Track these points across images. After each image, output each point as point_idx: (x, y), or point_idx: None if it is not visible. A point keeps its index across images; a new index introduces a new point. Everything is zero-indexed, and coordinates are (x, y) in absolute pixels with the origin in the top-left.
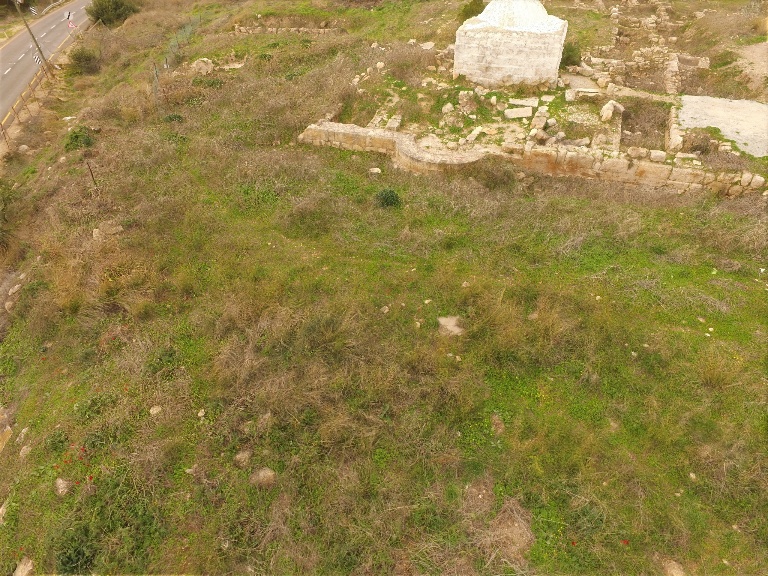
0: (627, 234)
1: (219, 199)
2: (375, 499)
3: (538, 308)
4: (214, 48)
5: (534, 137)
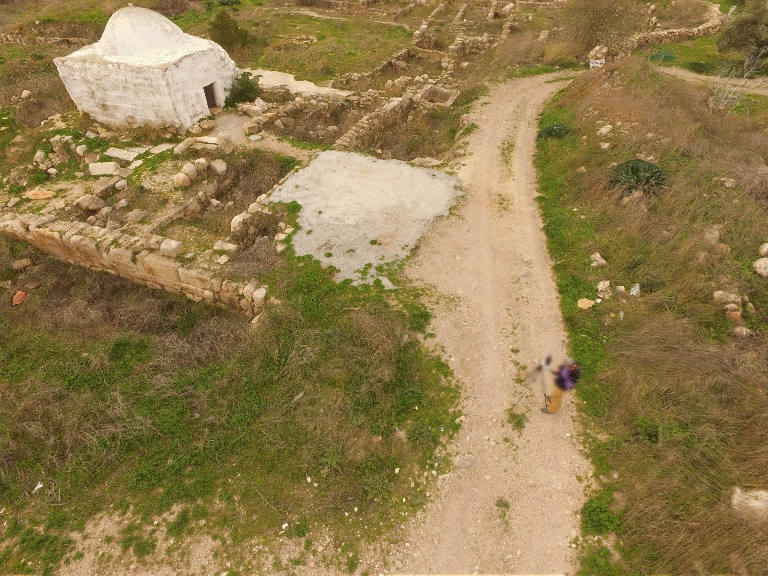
0: None
1: None
2: None
3: None
4: None
5: (77, 207)
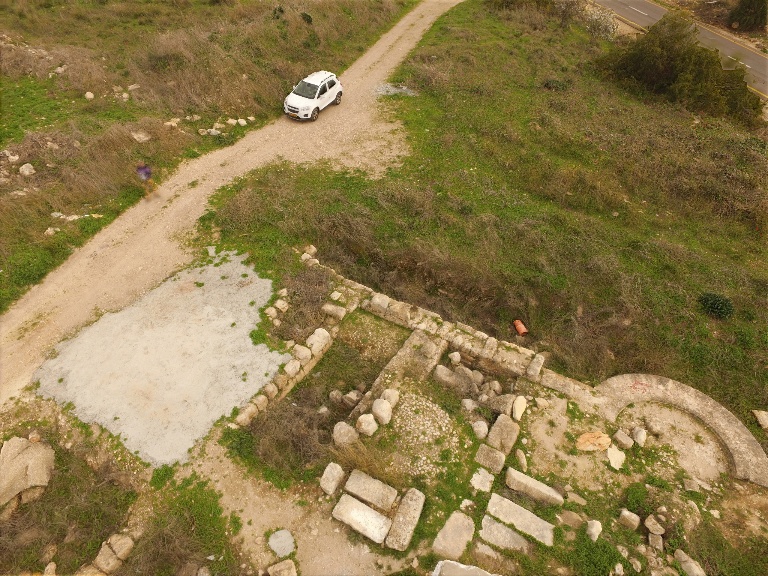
0: None
1: None
2: None
3: None
4: None
5: None
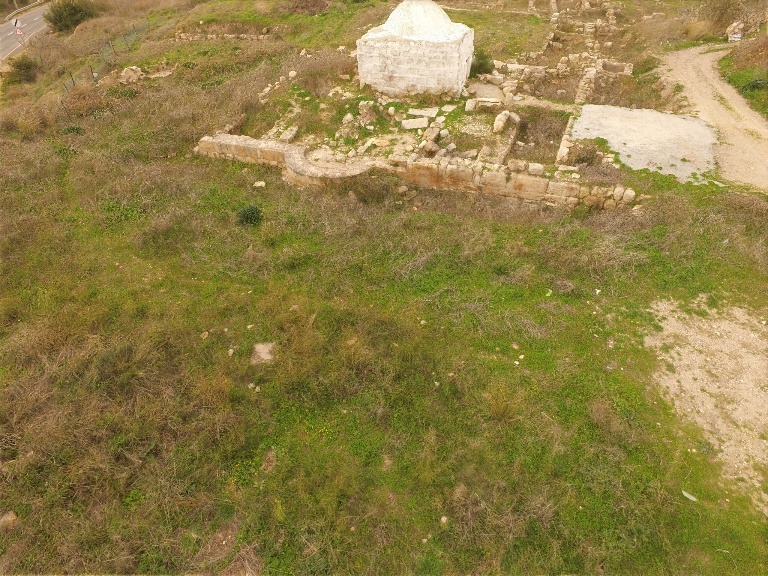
0: (474, 253)
1: (84, 216)
2: (104, 548)
3: (357, 334)
4: (146, 56)
5: (422, 149)
